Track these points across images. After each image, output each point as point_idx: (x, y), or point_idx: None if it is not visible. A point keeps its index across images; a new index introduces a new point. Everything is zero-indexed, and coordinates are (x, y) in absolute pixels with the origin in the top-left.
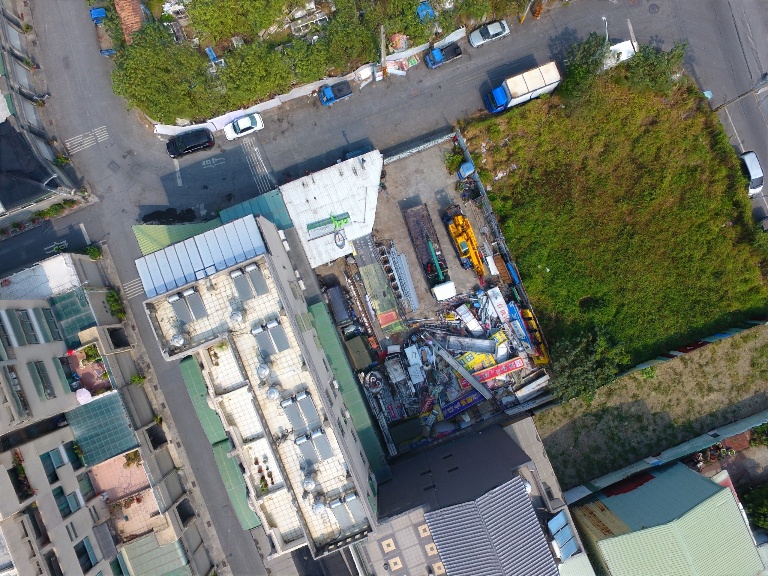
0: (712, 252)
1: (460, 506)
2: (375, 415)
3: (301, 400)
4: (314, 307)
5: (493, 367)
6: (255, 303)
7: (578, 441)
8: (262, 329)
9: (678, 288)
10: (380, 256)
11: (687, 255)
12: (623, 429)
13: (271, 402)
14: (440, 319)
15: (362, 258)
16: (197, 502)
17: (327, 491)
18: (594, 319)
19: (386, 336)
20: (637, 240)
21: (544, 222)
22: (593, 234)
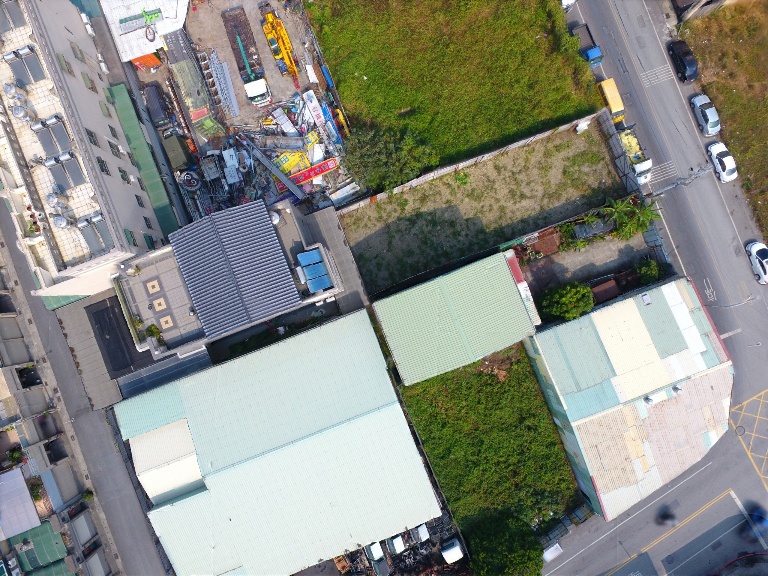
0: (525, 61)
1: (198, 222)
2: (190, 213)
3: (53, 126)
4: (115, 88)
5: (307, 169)
6: (13, 35)
7: (392, 245)
8: (13, 54)
9: (492, 97)
10: (201, 62)
11: (502, 66)
12: (436, 234)
13: (26, 130)
14: (260, 125)
15: (174, 54)
16: (19, 300)
17: (79, 217)
18: (408, 125)
19: (201, 135)
20: (453, 50)
21: (363, 32)
22: (411, 44)
